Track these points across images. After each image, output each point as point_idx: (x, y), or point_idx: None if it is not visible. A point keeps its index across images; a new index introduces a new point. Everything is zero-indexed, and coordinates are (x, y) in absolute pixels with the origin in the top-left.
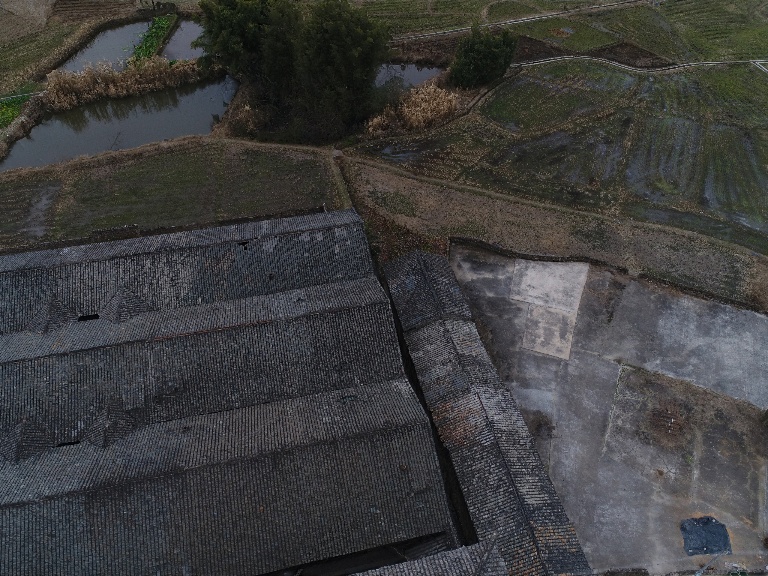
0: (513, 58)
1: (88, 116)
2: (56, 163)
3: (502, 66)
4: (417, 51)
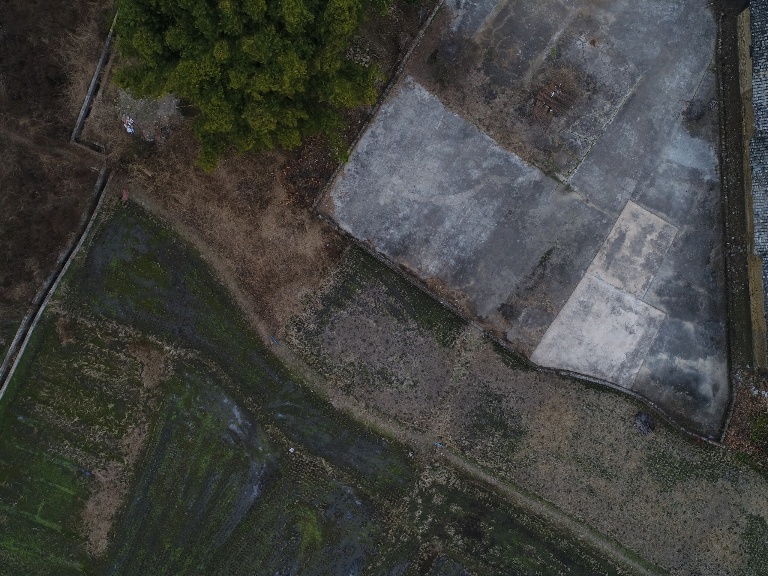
0: None
1: None
2: None
3: None
4: None
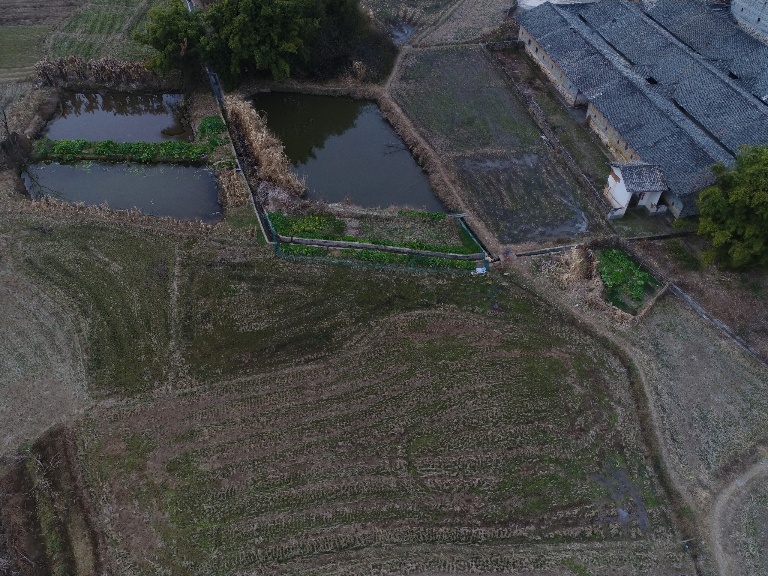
0: None
1: None
2: None
3: None
4: None
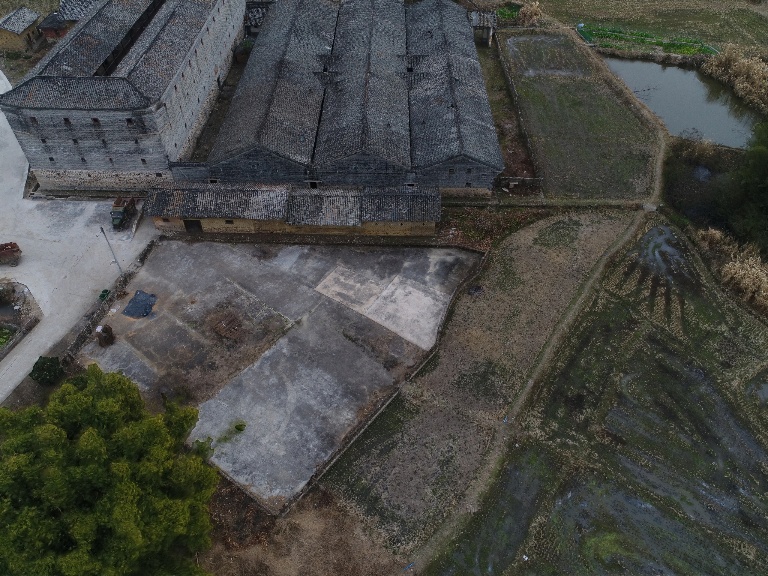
0: None
1: (721, 96)
2: (620, 76)
3: None
4: None
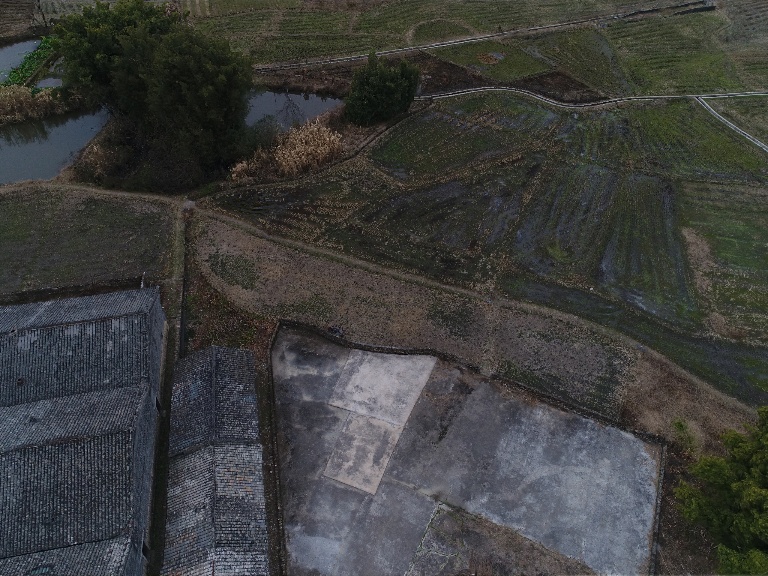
0: (427, 88)
1: None
2: None
3: (401, 101)
4: (320, 79)
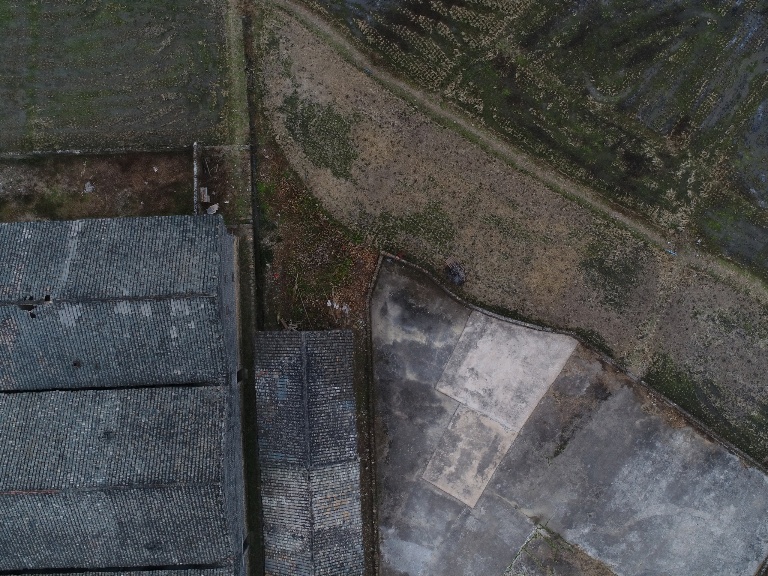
0: None
1: None
2: None
3: None
4: None
